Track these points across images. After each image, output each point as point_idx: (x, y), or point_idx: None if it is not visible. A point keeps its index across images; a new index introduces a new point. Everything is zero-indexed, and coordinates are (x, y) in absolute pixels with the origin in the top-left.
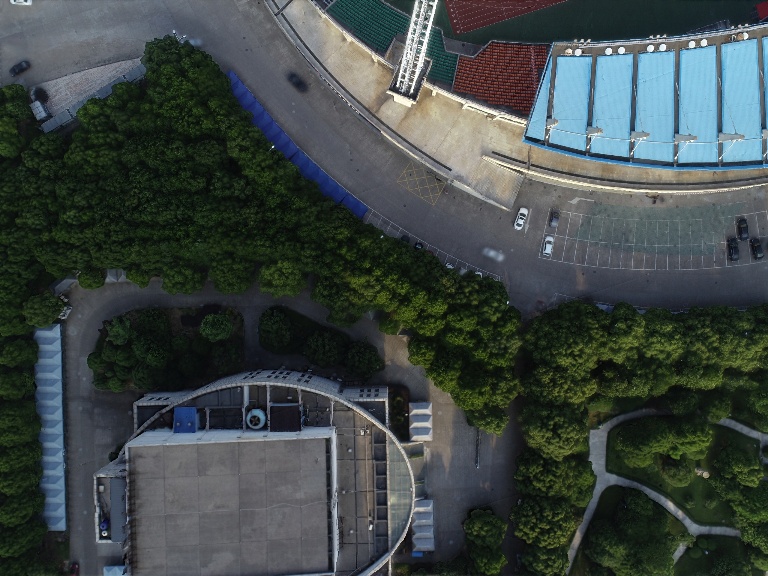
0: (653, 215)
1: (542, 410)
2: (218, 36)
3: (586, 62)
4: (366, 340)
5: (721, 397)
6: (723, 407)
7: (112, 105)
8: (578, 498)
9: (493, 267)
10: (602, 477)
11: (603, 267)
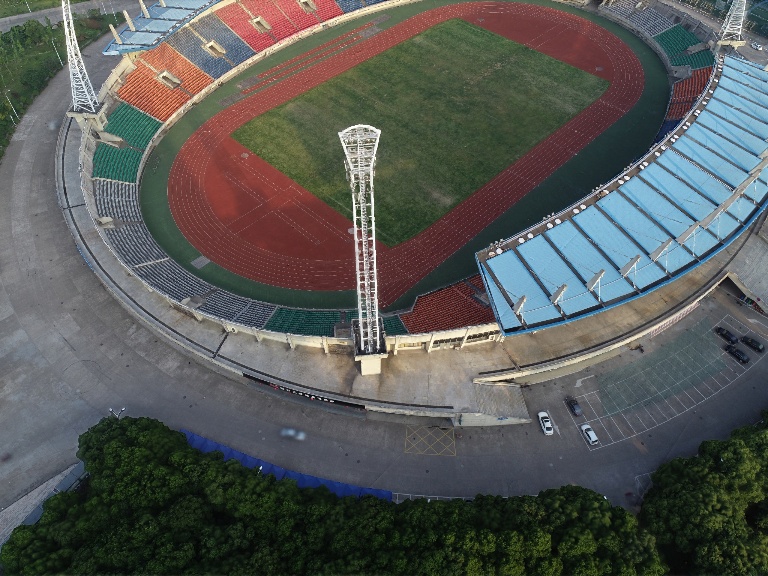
0: (651, 361)
1: None
2: (156, 408)
3: (510, 255)
4: None
5: None
6: None
7: (47, 521)
8: None
9: (556, 485)
10: None
11: (653, 427)
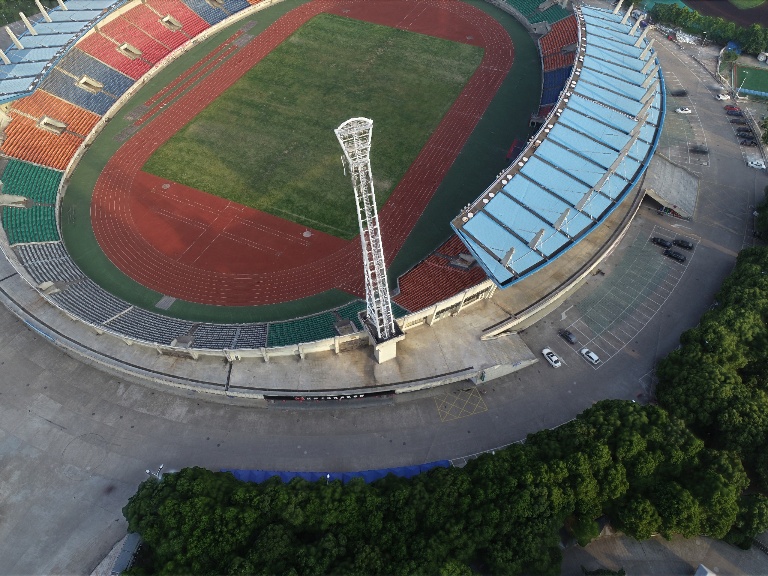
0: (612, 281)
1: None
2: (182, 458)
3: (481, 216)
4: (585, 570)
5: None
6: None
7: None
8: None
9: (581, 407)
10: None
11: (636, 335)
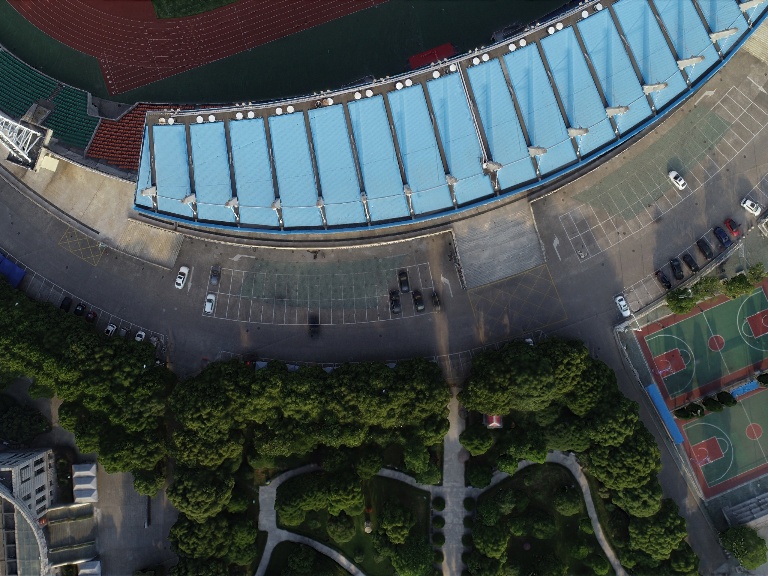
0: (315, 270)
1: (174, 474)
2: None
3: (180, 130)
4: (24, 404)
5: (367, 454)
6: (368, 464)
7: None
8: (237, 557)
9: (157, 326)
10: (273, 533)
11: (267, 323)
